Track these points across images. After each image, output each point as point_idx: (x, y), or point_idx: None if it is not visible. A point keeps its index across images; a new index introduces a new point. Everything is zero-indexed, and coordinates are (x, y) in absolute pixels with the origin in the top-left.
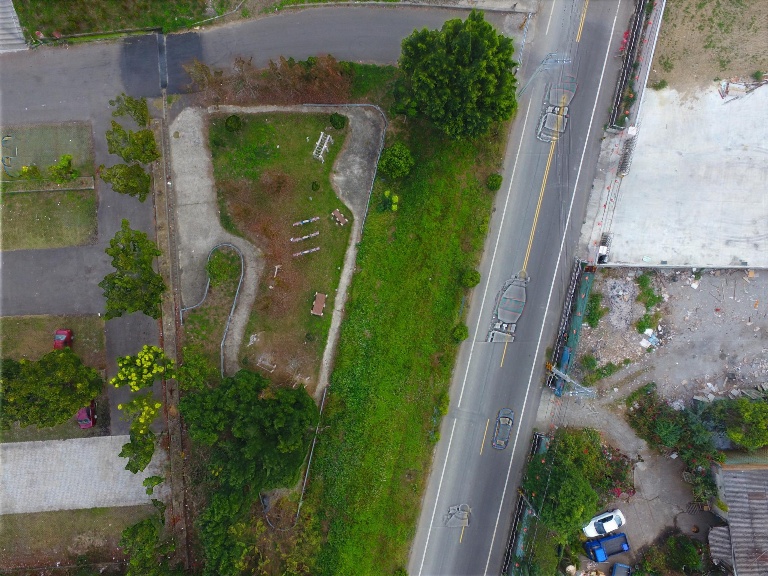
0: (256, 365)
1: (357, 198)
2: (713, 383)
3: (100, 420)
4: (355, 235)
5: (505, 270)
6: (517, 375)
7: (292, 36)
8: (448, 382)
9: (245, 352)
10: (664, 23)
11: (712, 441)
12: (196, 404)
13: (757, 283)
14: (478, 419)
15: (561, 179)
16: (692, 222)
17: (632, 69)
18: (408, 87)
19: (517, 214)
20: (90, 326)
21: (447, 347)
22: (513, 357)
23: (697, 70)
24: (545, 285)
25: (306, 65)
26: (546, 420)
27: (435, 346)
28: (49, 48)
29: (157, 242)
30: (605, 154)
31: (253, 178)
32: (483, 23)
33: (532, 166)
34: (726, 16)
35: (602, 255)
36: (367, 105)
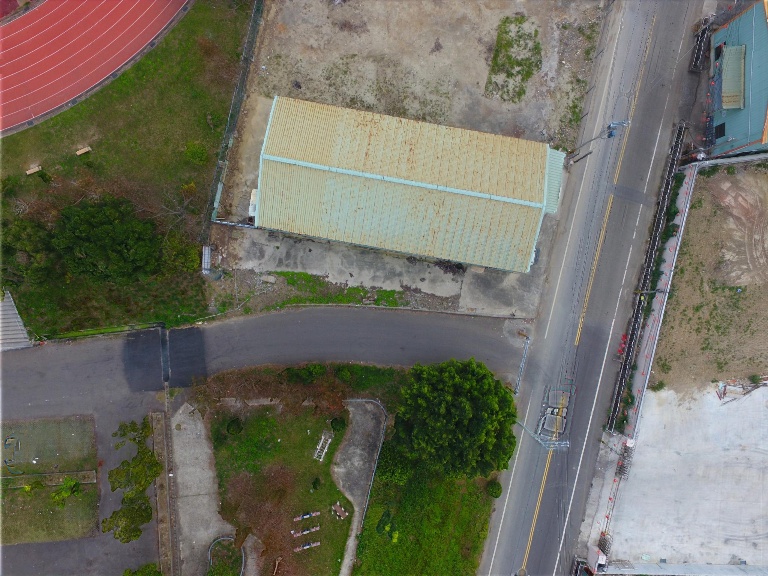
0: None
1: (357, 489)
2: None
3: None
4: (355, 526)
5: (505, 569)
6: None
7: (293, 334)
8: None
9: None
10: (662, 325)
11: None
12: None
13: None
14: None
15: (560, 479)
16: (691, 521)
17: (630, 370)
18: (408, 430)
19: (517, 514)
20: None
21: None
22: None
23: (695, 371)
24: None
25: (307, 374)
26: None
27: None
28: (53, 345)
29: (158, 534)
30: (604, 453)
31: (254, 471)
32: (482, 375)
33: (531, 466)
34: (723, 319)
35: None
36: (368, 400)
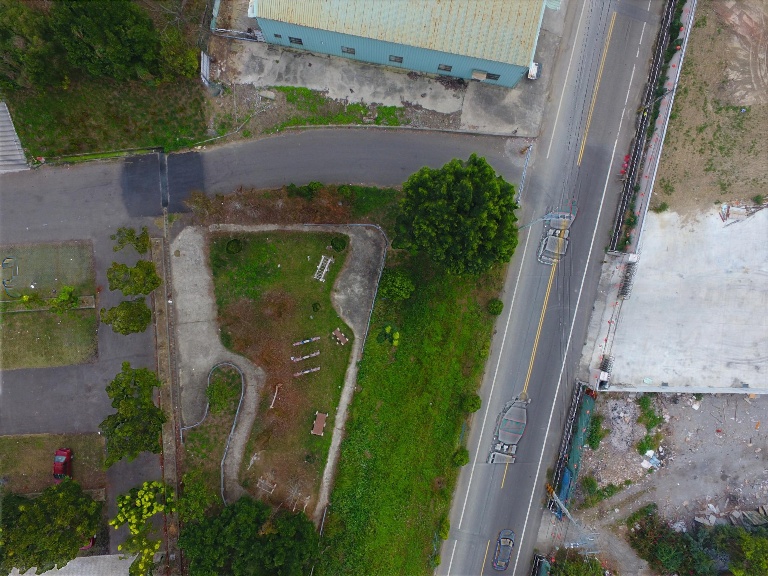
0: (256, 484)
1: (358, 316)
2: (714, 504)
3: (99, 539)
4: (356, 353)
5: (506, 392)
6: (518, 496)
7: (293, 157)
8: (449, 505)
9: (245, 471)
10: (665, 146)
11: (713, 568)
12: (196, 539)
13: (758, 404)
14: (479, 540)
15: (562, 301)
16: (693, 344)
17: (633, 192)
18: (409, 227)
19: (518, 336)
20: (90, 445)
21: (448, 471)
22: (514, 478)
23: (698, 193)
24: (546, 406)
25: (307, 191)
26: (547, 541)
27: (436, 471)
28: (50, 168)
29: (157, 361)
30: (606, 276)
31: (254, 297)
32: (484, 166)
33: (533, 288)
34: (727, 139)
35: (603, 380)
36: (368, 225)
